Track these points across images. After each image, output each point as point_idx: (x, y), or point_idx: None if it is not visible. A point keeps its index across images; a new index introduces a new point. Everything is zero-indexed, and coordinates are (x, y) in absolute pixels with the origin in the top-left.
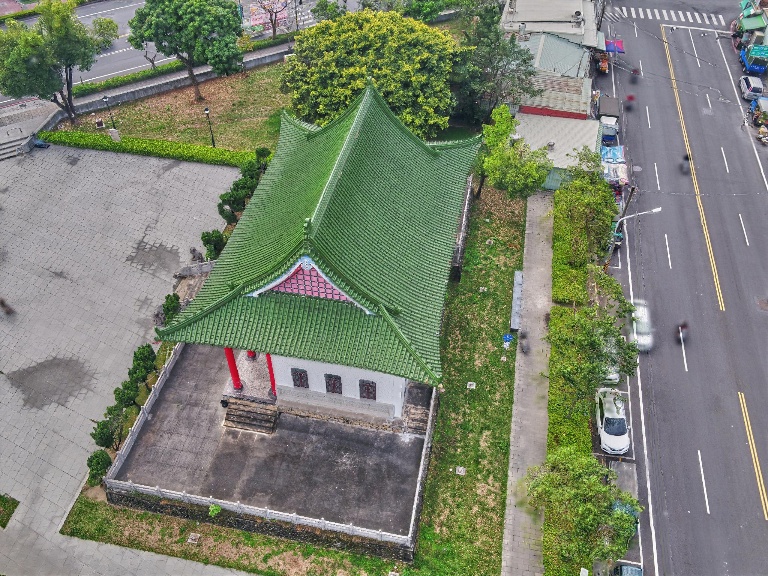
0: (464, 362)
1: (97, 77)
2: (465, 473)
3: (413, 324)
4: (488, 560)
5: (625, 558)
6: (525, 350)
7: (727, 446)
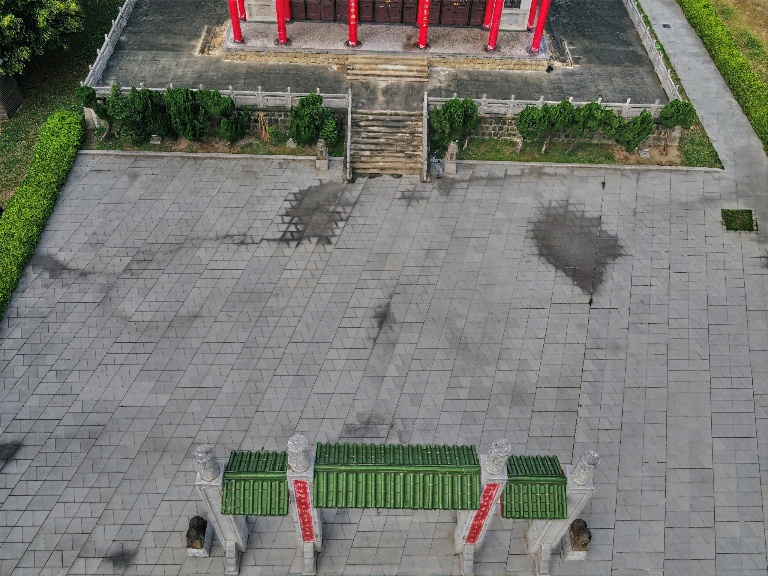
0: None
1: None
2: None
3: None
4: None
5: None
6: None
7: None
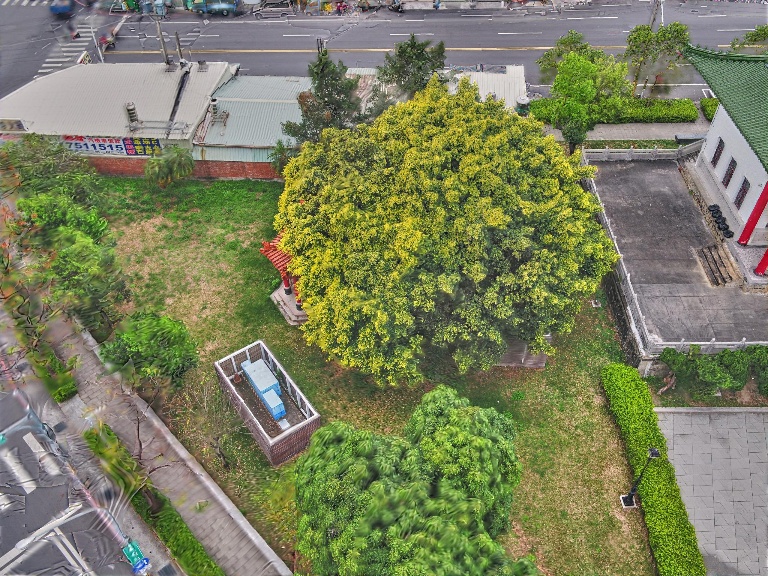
0: None
1: None
2: None
3: None
4: None
5: None
6: None
7: None
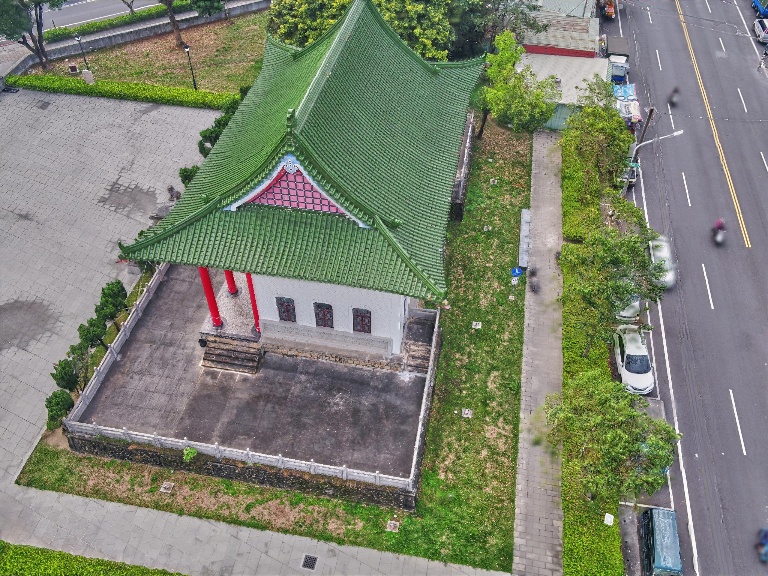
0: (468, 301)
1: (72, 24)
2: (472, 415)
3: (413, 240)
4: (500, 507)
5: (654, 504)
6: (535, 289)
7: (761, 385)
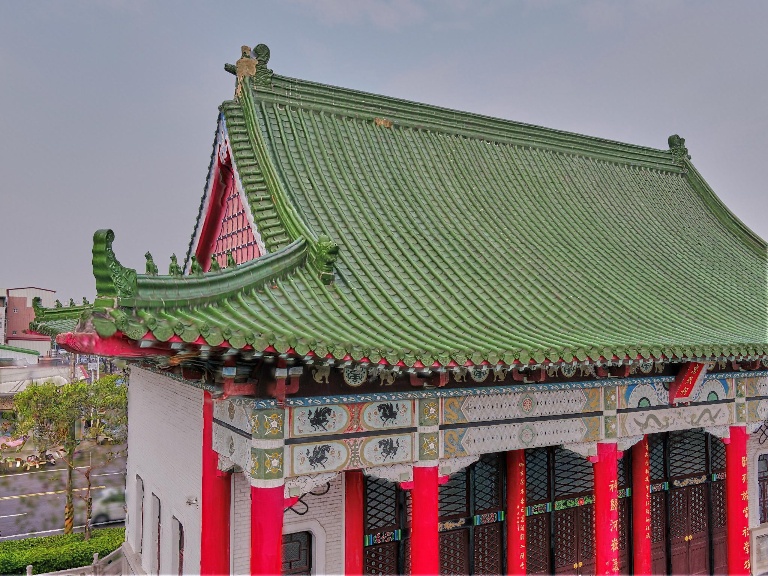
0: None
1: None
2: None
3: None
4: None
5: None
6: None
7: None
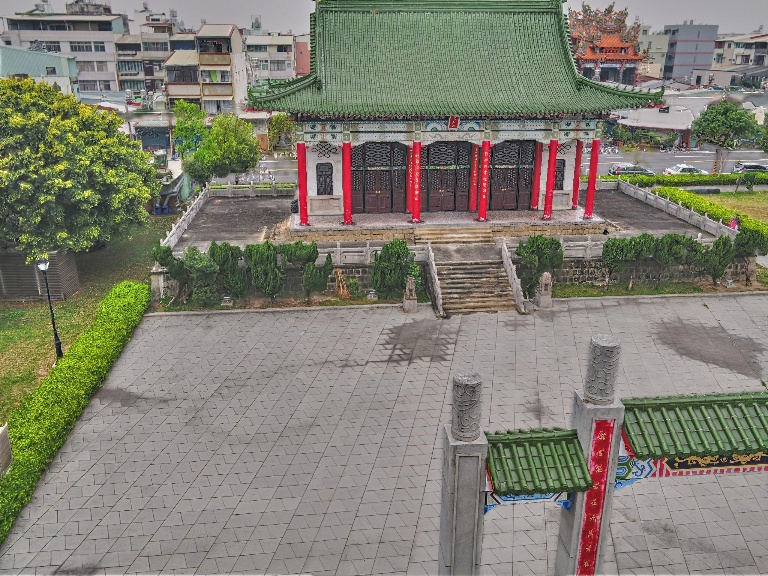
0: None
1: None
2: None
3: None
4: None
5: None
6: None
7: None
